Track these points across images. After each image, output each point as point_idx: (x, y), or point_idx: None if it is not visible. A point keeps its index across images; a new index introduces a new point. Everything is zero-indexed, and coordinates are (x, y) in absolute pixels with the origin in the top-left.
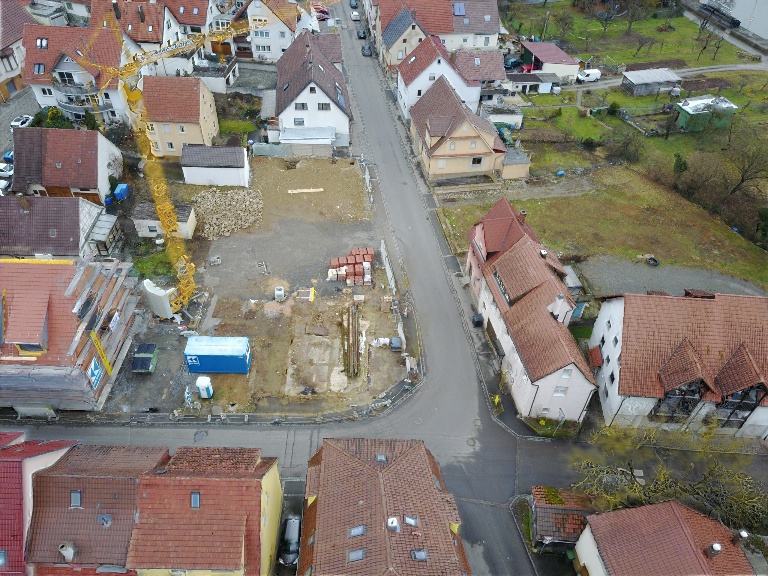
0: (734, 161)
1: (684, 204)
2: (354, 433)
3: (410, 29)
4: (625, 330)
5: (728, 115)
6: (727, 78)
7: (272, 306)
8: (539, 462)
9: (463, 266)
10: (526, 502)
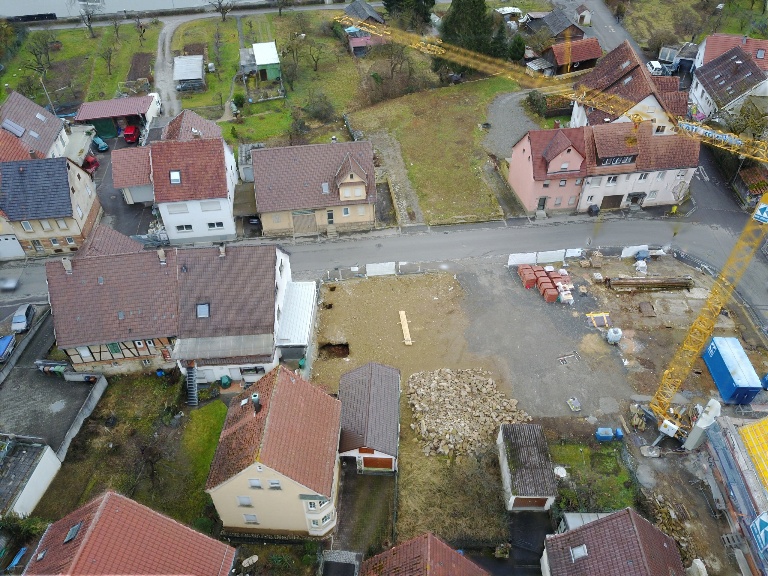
0: (383, 56)
1: (408, 99)
2: (746, 285)
3: (67, 172)
4: (665, 108)
5: (307, 43)
6: (187, 42)
7: (631, 343)
8: (712, 201)
9: (520, 215)
10: (749, 209)
